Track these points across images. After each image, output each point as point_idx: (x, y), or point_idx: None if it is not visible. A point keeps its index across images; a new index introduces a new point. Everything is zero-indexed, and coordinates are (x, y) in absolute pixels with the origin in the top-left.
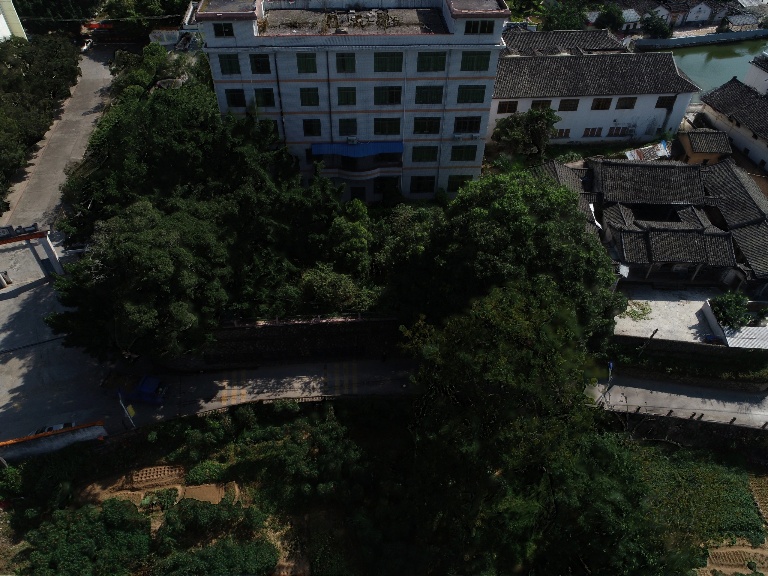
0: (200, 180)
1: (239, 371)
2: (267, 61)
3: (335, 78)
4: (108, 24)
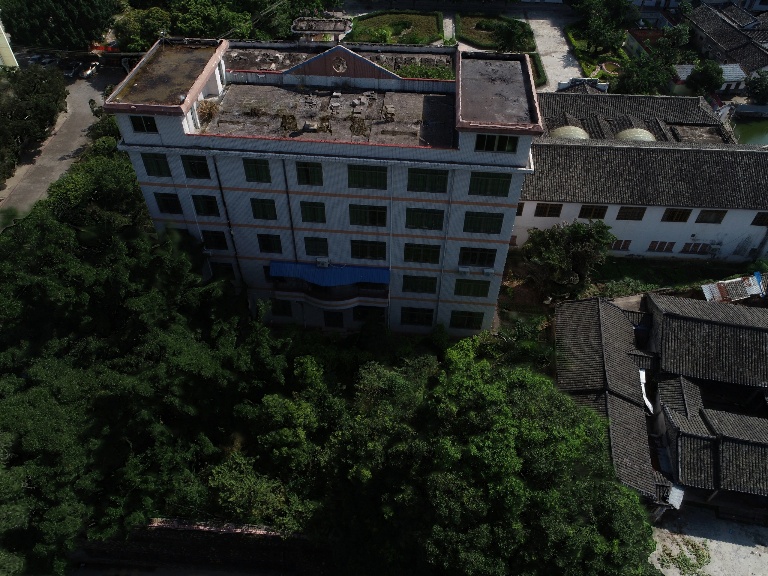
0: (84, 333)
1: (130, 571)
2: (205, 164)
3: (296, 190)
4: (116, 47)
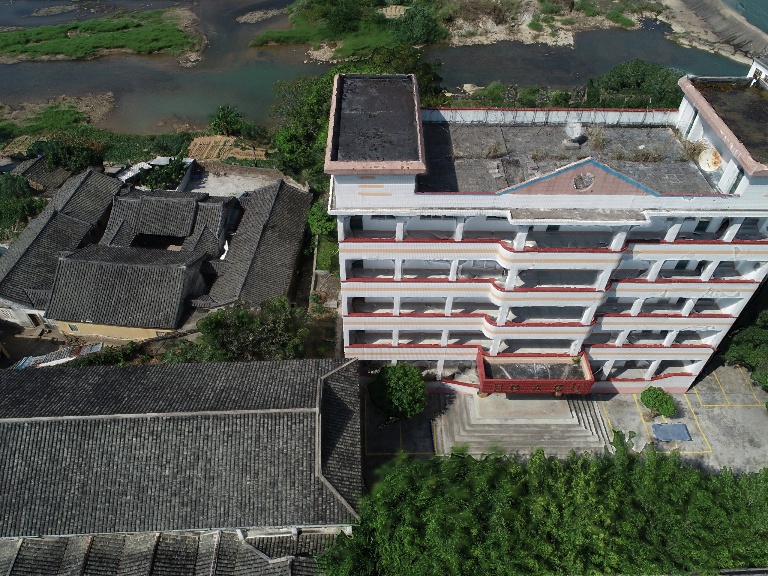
0: None
1: None
2: None
3: None
4: None
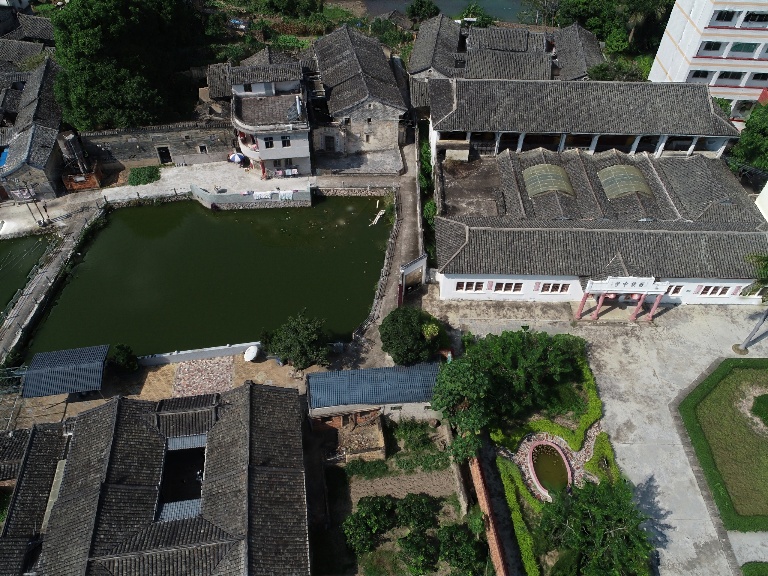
0: None
1: None
2: None
3: None
4: None
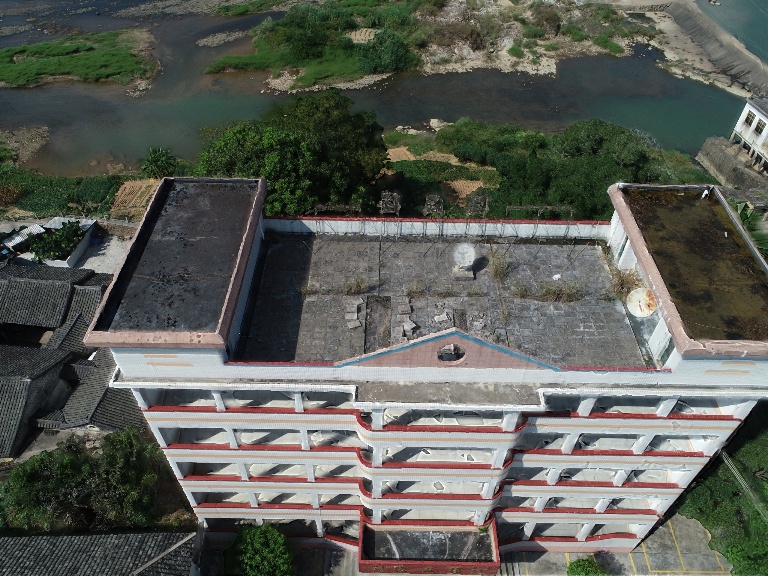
0: None
1: None
2: None
3: None
4: None
